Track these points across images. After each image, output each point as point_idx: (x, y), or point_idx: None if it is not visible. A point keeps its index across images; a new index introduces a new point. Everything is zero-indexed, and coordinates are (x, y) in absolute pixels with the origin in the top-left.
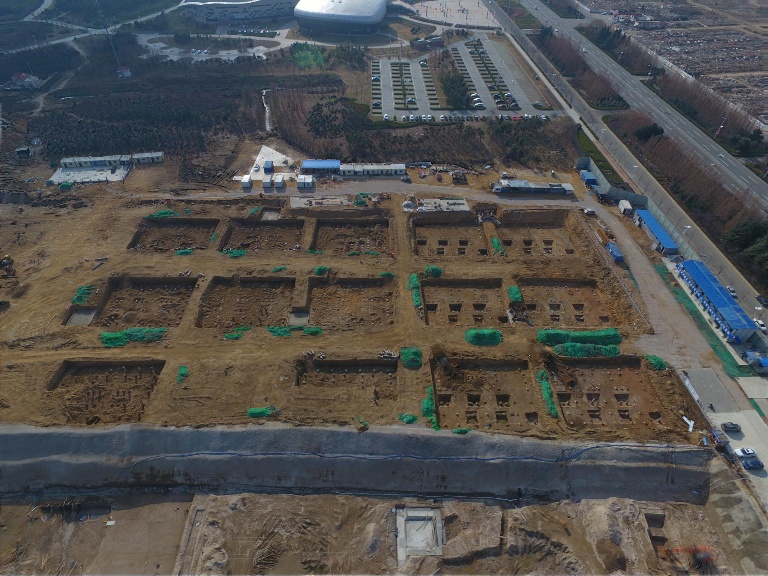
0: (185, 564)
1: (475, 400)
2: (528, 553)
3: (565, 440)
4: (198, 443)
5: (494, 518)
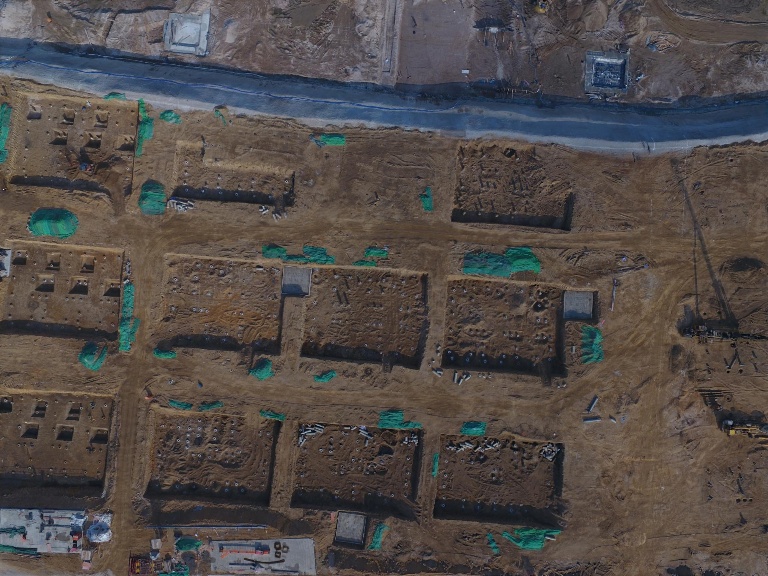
0: (391, 30)
1: (93, 144)
2: (94, 9)
3: (6, 76)
4: (394, 116)
5: (115, 36)
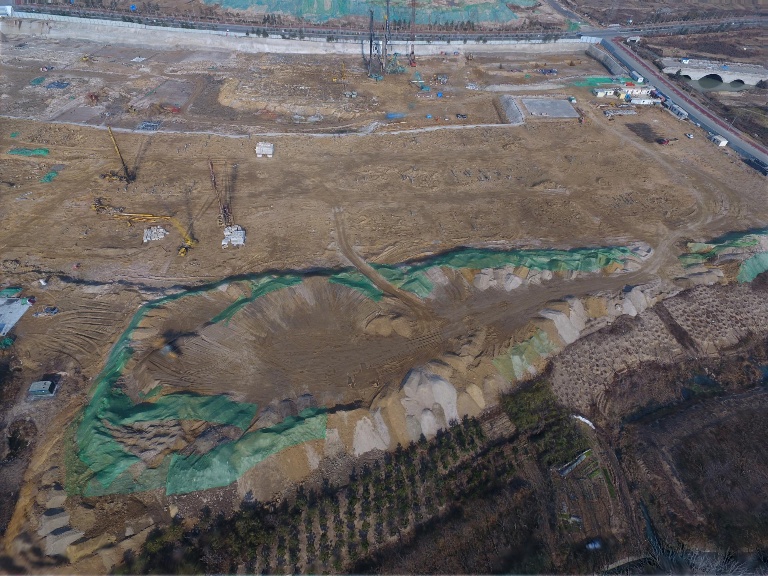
0: None
1: None
2: None
3: None
4: None
5: None
